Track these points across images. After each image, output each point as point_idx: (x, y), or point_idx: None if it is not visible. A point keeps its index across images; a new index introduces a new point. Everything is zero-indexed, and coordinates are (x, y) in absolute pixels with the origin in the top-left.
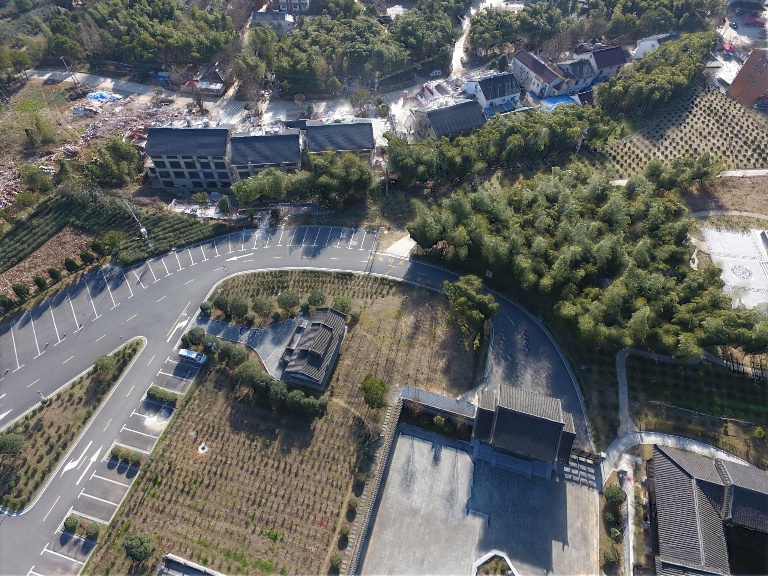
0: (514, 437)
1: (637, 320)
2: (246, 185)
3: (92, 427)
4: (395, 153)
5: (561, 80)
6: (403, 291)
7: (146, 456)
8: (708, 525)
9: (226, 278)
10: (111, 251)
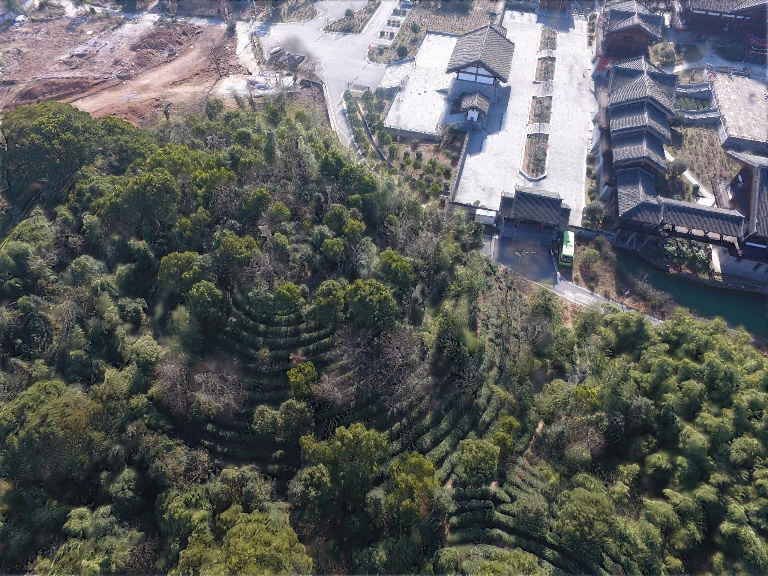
0: None
1: None
2: None
3: (375, 18)
4: None
5: None
6: None
7: (401, 23)
8: None
9: None
10: None
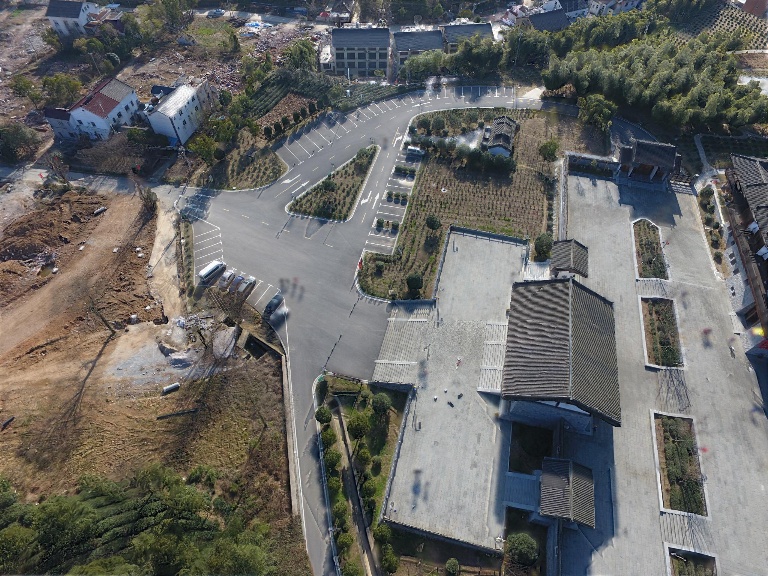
0: (647, 157)
1: (711, 103)
2: None
3: (368, 185)
4: (518, 36)
5: (615, 2)
6: (543, 115)
7: (409, 196)
8: (767, 179)
9: (417, 115)
10: (330, 104)
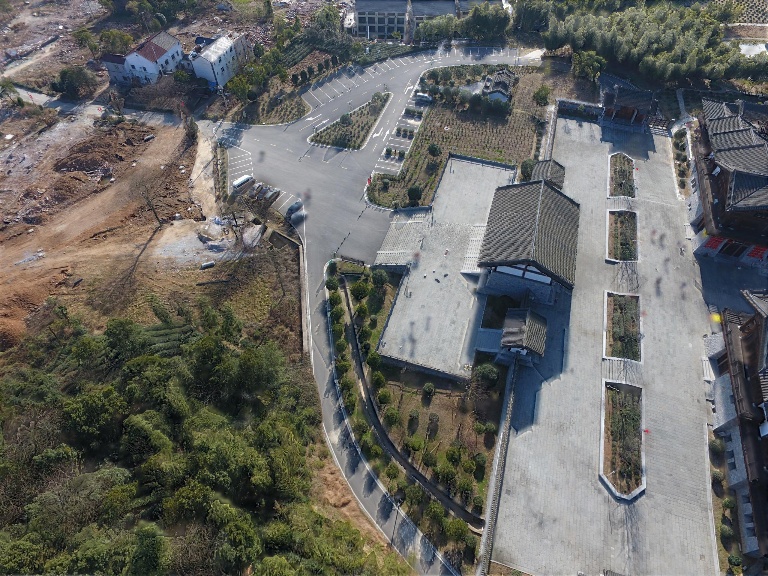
0: (627, 100)
1: (691, 58)
2: (430, 22)
3: (380, 123)
4: None
5: None
6: (542, 71)
7: (415, 132)
8: None
9: (428, 69)
10: (351, 59)
